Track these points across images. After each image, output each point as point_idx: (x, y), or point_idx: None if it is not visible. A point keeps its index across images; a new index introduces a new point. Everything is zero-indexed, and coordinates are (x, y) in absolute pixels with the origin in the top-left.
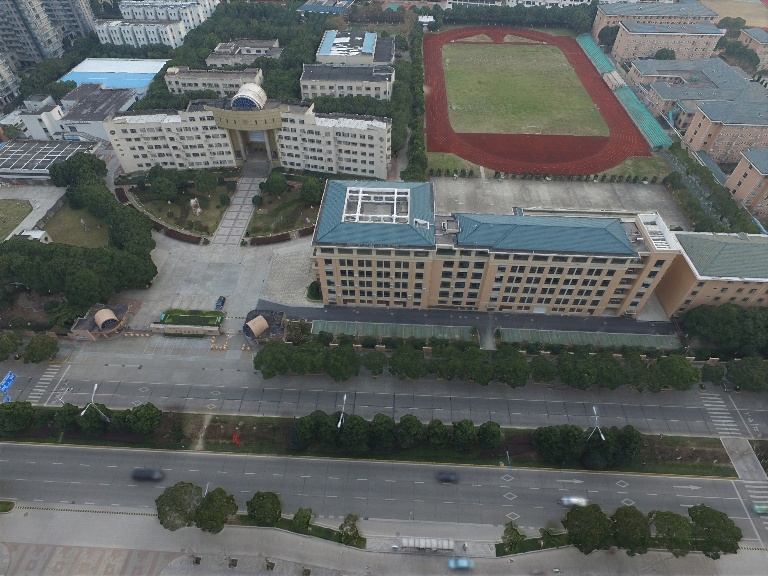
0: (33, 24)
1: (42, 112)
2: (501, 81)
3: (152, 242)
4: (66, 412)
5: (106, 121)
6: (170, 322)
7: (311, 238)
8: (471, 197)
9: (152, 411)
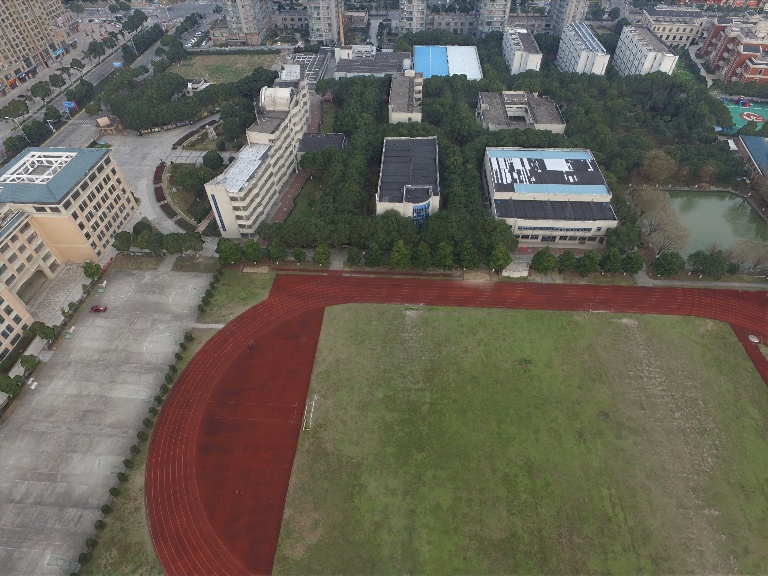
0: (483, 4)
1: (341, 48)
2: (541, 401)
3: (157, 118)
4: (32, 121)
5: (284, 61)
6: (90, 144)
7: (151, 195)
8: (157, 307)
9: (10, 144)
